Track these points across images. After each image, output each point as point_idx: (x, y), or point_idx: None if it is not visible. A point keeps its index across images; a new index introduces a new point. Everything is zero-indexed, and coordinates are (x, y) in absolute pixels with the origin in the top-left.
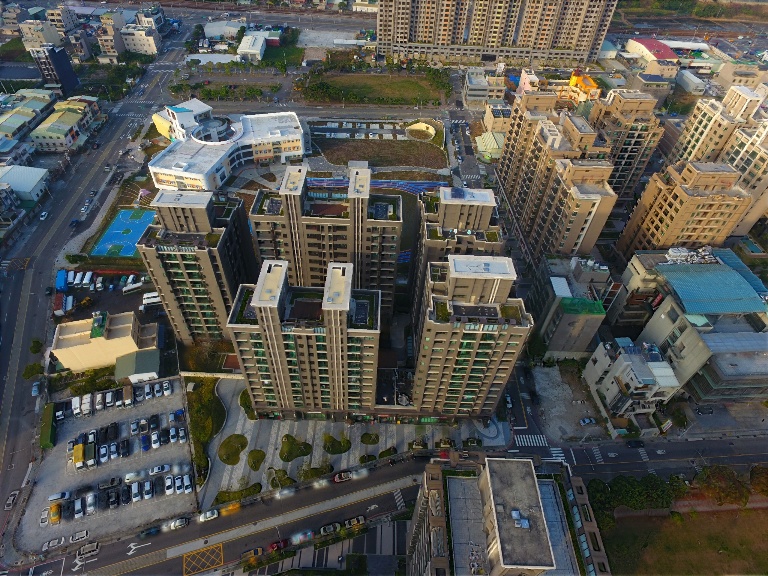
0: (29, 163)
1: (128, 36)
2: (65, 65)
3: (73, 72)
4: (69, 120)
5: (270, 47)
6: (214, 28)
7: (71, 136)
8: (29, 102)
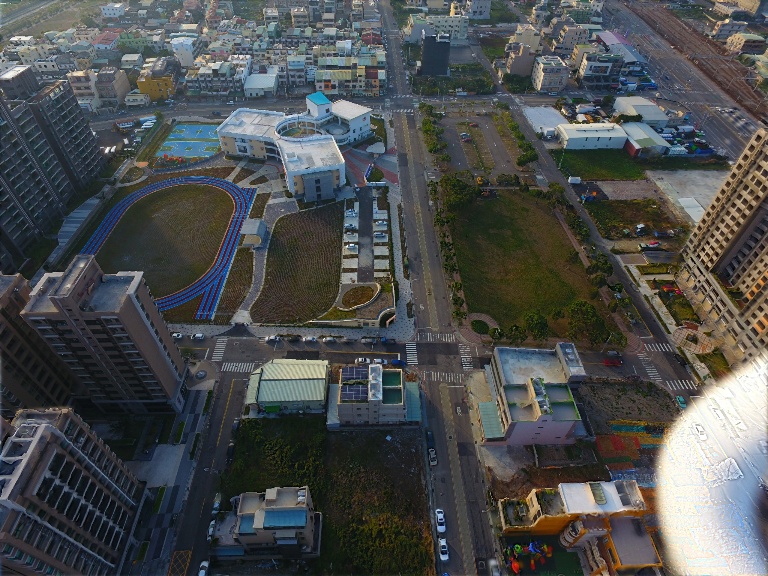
0: (302, 85)
1: (537, 64)
2: (440, 55)
3: (447, 64)
4: (338, 76)
5: (623, 151)
6: (624, 102)
7: (325, 85)
8: (366, 59)
